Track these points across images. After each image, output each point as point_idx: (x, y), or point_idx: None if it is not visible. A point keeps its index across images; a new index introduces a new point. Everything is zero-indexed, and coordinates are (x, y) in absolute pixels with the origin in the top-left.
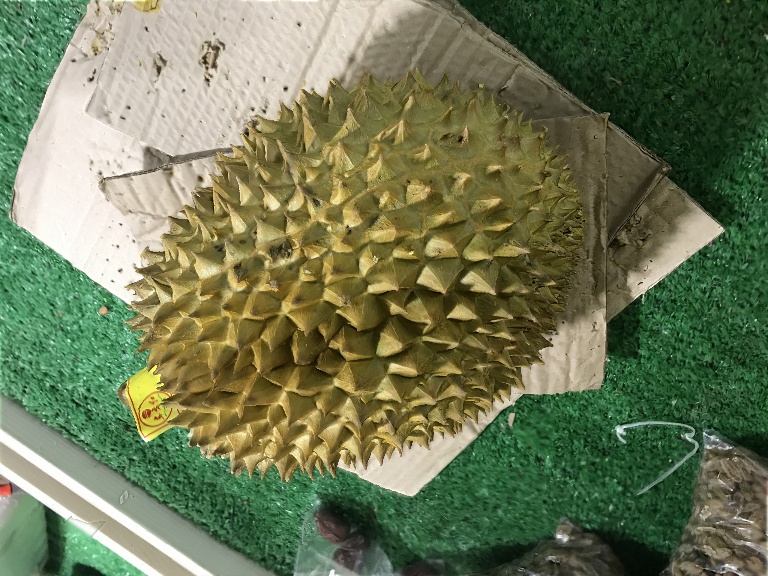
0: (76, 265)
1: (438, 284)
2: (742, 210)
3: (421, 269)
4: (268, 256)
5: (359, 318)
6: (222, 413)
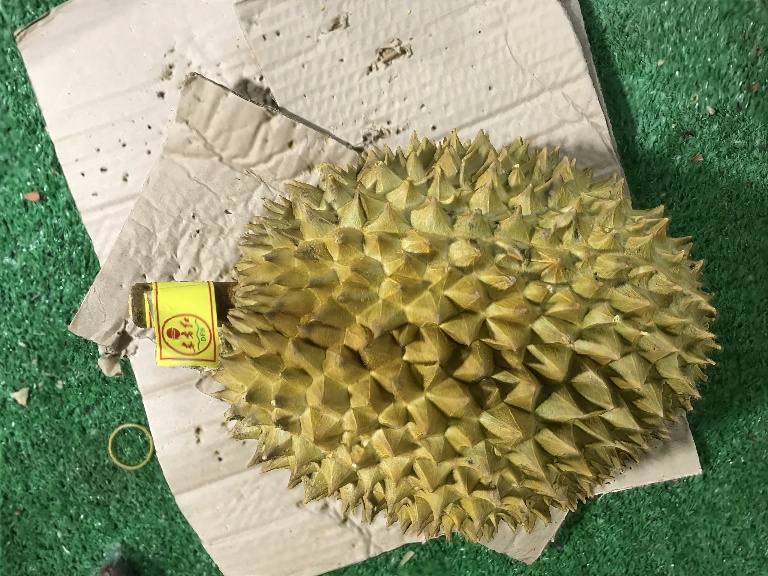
0: (50, 131)
1: (636, 377)
2: (714, 464)
3: (624, 354)
4: (517, 251)
5: (562, 365)
6: (327, 381)
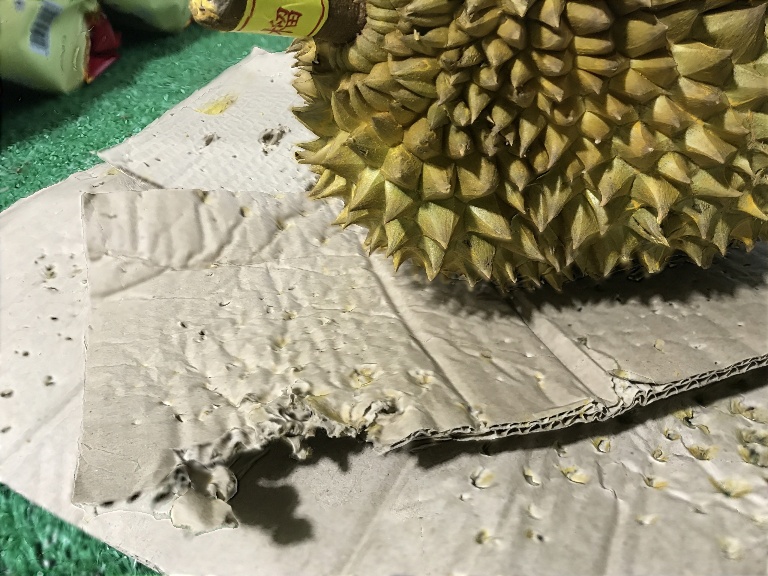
0: None
1: None
2: None
3: None
4: None
5: None
6: None
